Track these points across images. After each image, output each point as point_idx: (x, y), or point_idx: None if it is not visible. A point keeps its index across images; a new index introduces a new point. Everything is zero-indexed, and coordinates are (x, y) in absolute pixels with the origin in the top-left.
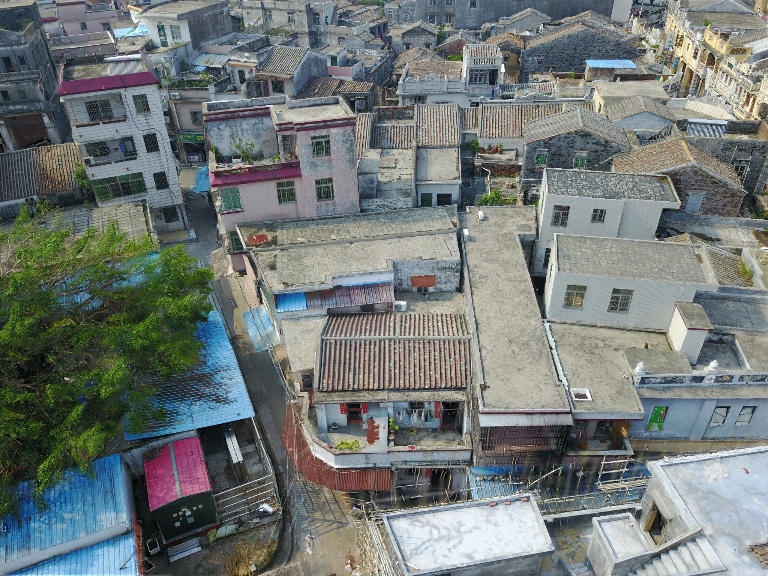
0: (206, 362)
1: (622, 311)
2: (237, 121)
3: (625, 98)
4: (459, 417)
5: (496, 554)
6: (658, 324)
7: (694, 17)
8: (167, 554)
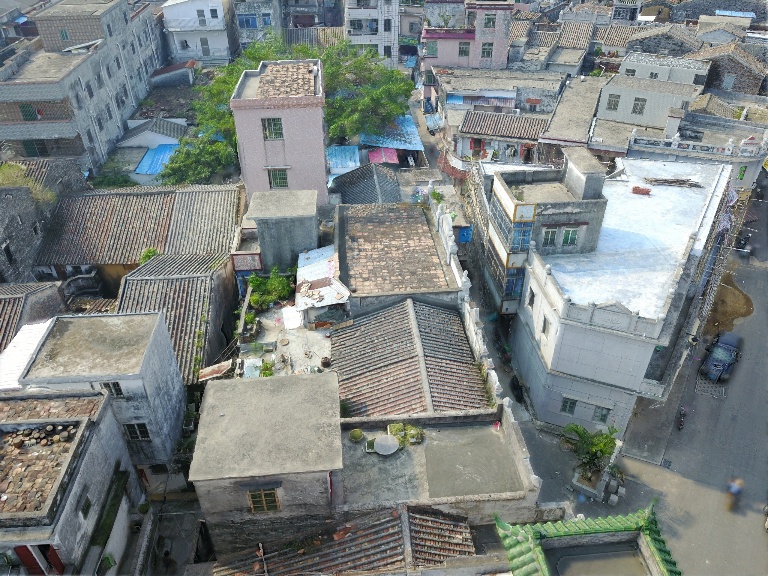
0: (402, 130)
1: (640, 114)
2: (444, 4)
3: (715, 24)
4: (533, 158)
5: None
6: (660, 123)
7: None
8: None
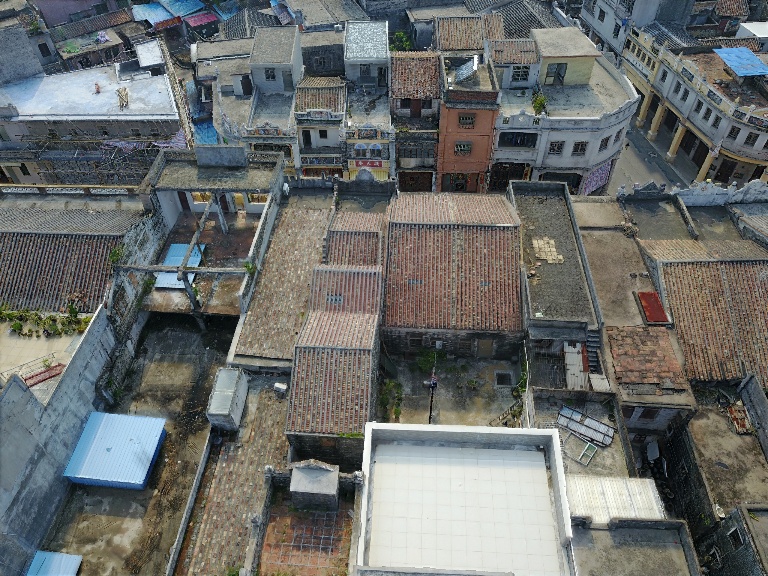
0: None
1: None
2: None
3: None
4: None
5: (141, 58)
6: None
7: None
8: (186, 42)
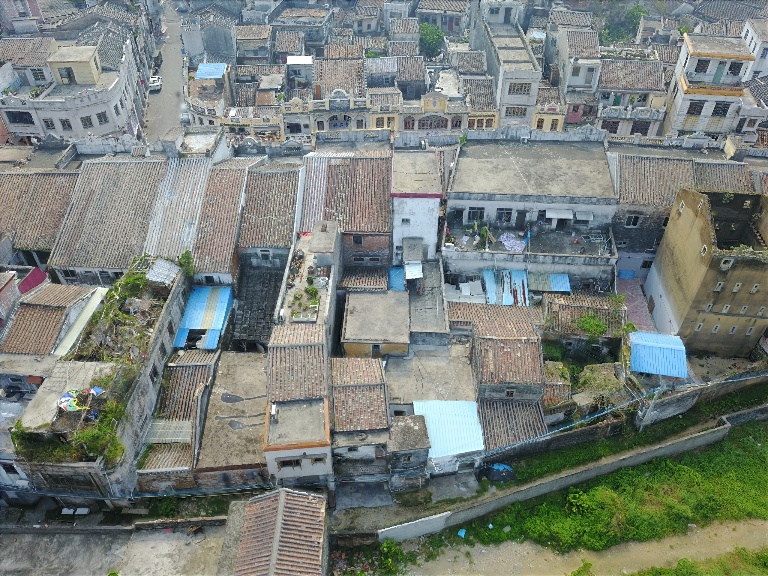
0: None
1: None
2: None
3: None
4: None
5: None
6: None
7: (561, 151)
8: None
